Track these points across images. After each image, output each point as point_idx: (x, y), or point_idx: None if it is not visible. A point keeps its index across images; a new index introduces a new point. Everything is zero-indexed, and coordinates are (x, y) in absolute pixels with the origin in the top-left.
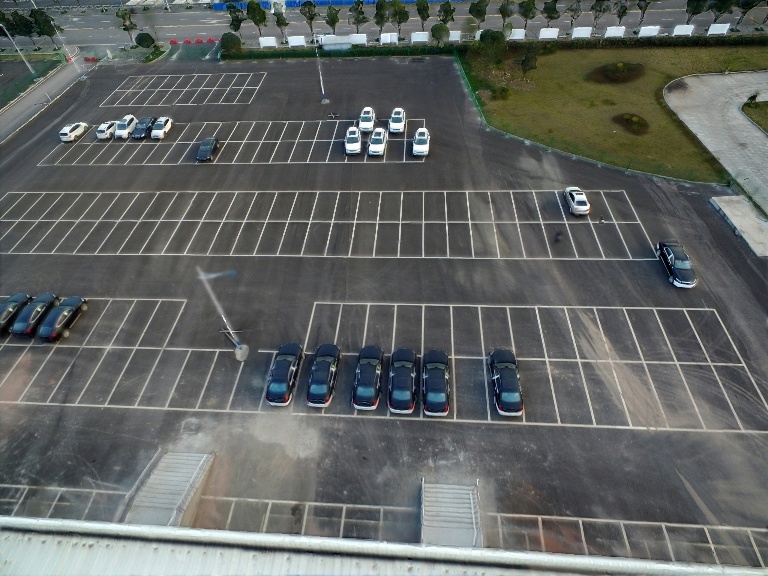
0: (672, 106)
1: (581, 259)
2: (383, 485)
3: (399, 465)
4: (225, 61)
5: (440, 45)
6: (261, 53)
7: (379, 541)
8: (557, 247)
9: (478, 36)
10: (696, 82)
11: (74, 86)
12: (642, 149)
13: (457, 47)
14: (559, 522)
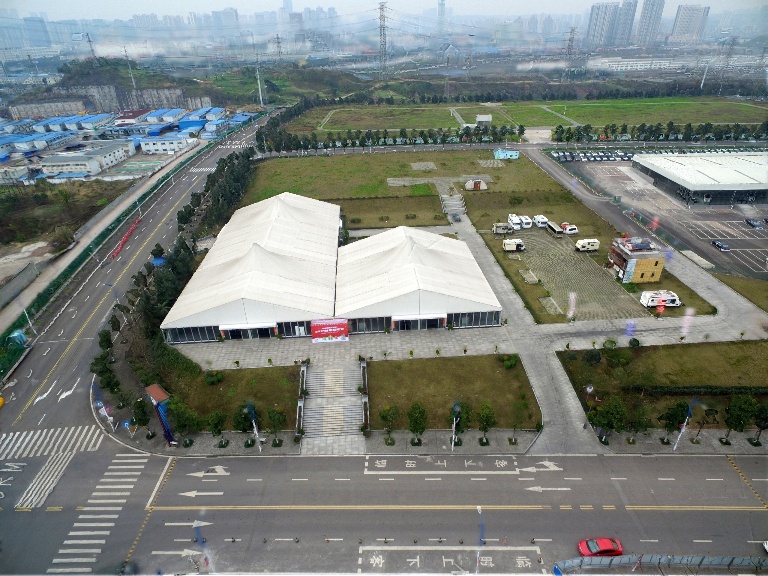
0: (764, 313)
1: (755, 249)
2: (765, 214)
3: (765, 216)
4: None
5: None
6: None
7: (763, 183)
8: (767, 252)
9: None
10: (759, 332)
11: None
12: (762, 288)
13: None
14: (723, 212)
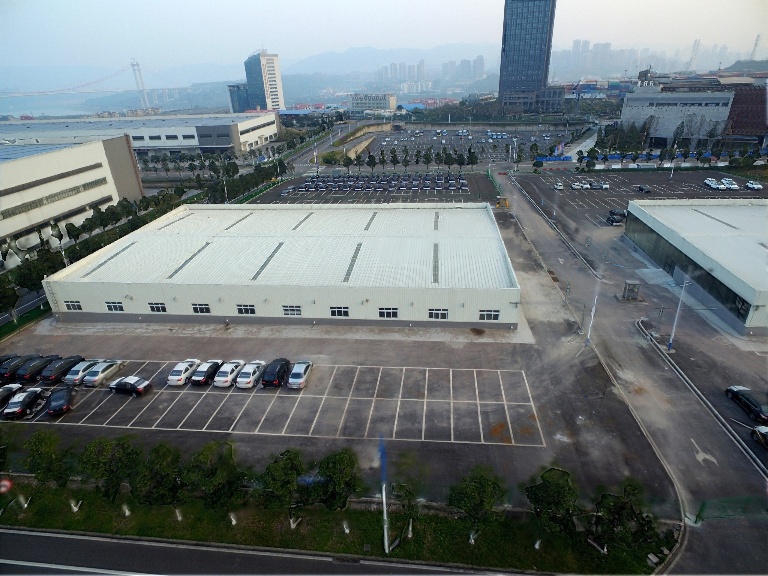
0: None
1: None
2: None
3: None
4: (585, 173)
5: (706, 166)
6: (606, 169)
7: None
8: None
9: (719, 165)
10: None
11: (516, 179)
12: None
13: (716, 167)
14: None
